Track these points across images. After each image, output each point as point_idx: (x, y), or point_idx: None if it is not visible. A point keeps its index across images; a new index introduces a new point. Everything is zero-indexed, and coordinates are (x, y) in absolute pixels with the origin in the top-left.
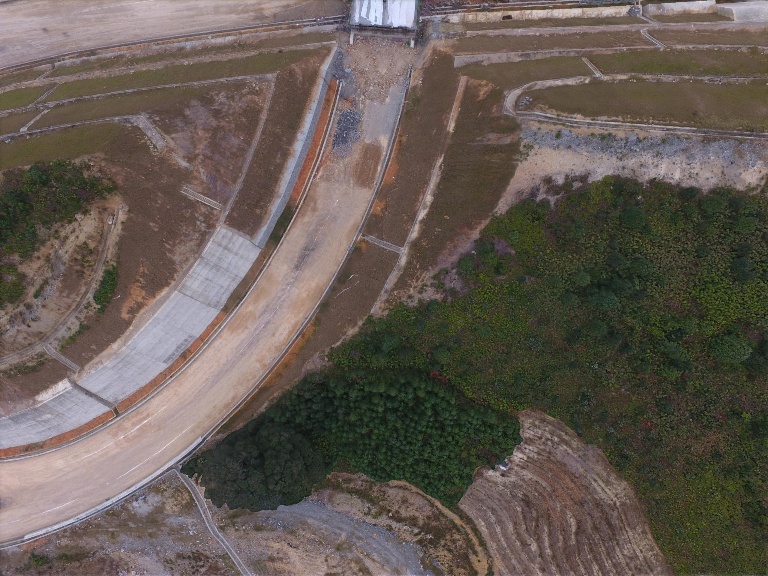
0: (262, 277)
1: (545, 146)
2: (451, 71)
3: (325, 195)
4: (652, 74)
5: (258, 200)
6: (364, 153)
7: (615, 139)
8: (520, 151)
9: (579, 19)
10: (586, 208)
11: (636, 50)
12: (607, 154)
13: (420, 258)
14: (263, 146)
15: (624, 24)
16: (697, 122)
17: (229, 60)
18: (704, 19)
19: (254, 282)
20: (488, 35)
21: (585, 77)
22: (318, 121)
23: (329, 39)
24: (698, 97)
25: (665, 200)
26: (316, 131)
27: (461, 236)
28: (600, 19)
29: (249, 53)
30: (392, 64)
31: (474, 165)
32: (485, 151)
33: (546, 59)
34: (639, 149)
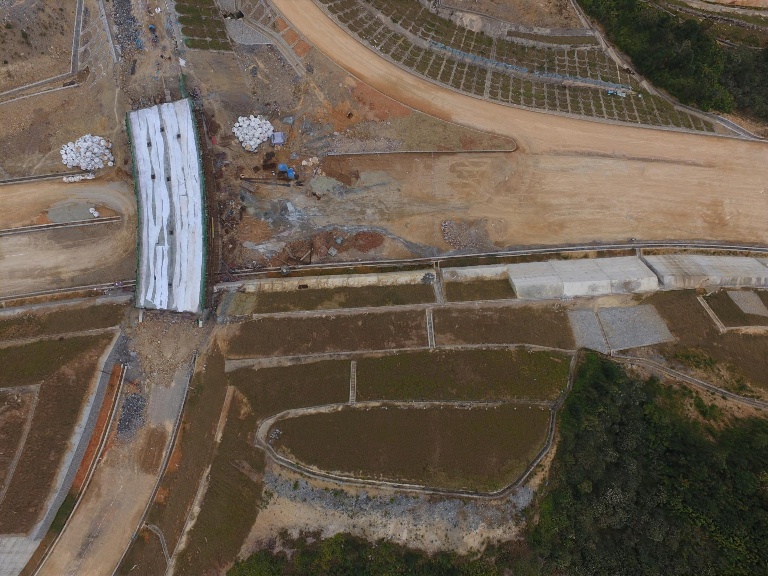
0: (45, 565)
1: (283, 496)
2: (222, 376)
3: (109, 480)
4: (403, 401)
5: (30, 500)
6: (148, 439)
7: (347, 496)
8: (261, 497)
9: (373, 289)
10: (320, 564)
11: (405, 352)
12: (339, 511)
13: (184, 575)
14: (29, 454)
15: (410, 304)
16: (425, 481)
17: (7, 348)
18: (488, 296)
19: (36, 571)
20: (274, 318)
21: (338, 405)
22: (101, 407)
23: (114, 322)
24: (438, 437)
25: (389, 567)
26: (99, 417)
27: (212, 570)
28: (393, 289)
29: (29, 340)
30: (176, 350)
31: (230, 491)
32: (239, 479)
33: (315, 364)
34: (369, 508)
